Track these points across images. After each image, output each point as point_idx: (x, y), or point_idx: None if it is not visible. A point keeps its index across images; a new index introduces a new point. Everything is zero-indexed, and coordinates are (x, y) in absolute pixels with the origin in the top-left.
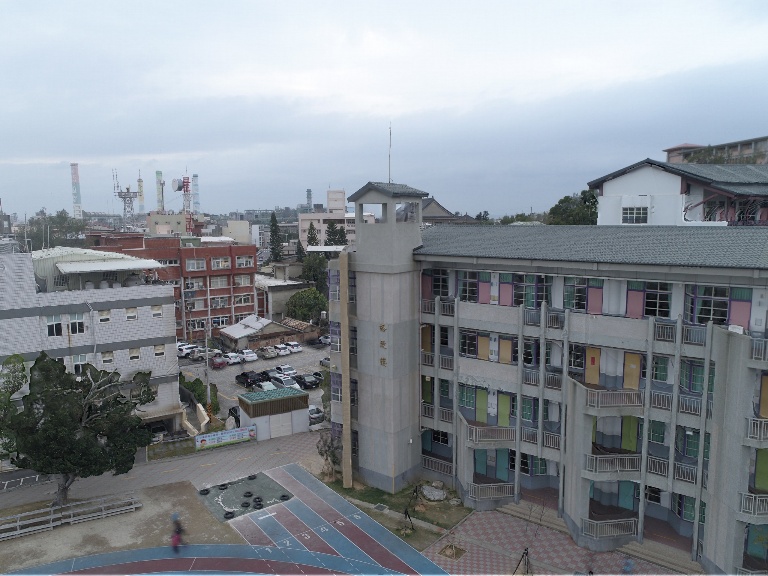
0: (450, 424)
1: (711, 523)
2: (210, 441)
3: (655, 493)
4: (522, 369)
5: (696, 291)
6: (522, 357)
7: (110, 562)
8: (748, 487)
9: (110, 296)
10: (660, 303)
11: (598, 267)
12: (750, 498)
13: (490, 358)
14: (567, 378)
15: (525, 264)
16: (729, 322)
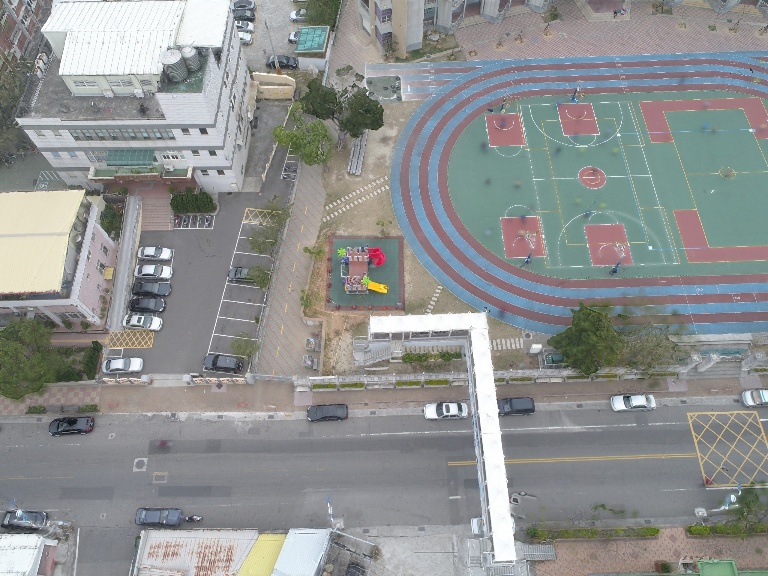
0: (433, 3)
1: None
2: (324, 83)
3: None
4: None
5: None
6: None
7: (407, 138)
8: None
9: (227, 42)
10: None
11: None
12: None
13: None
14: None
15: None
16: None
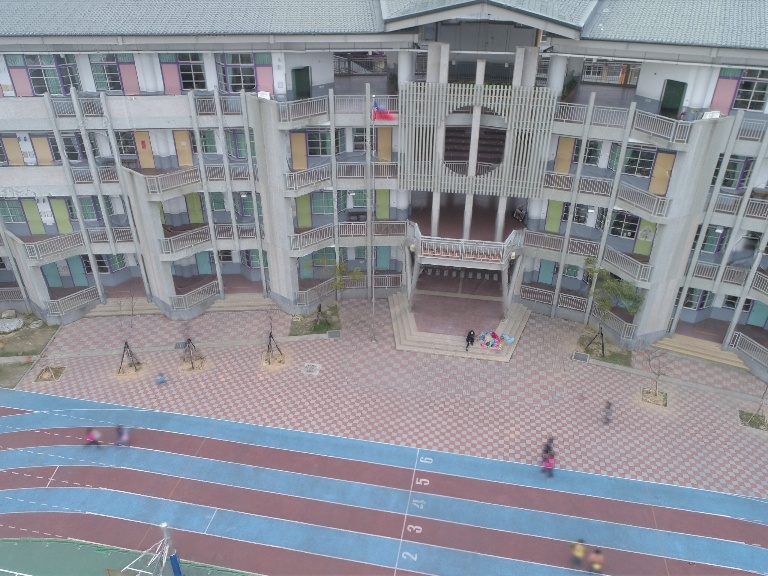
0: (1, 247)
1: (273, 265)
2: None
3: (227, 254)
4: (69, 168)
5: (225, 59)
6: (65, 154)
7: None
8: (294, 230)
9: None
10: (195, 75)
11: (123, 41)
12: (296, 238)
13: (26, 162)
14: (122, 169)
15: (35, 42)
16: (258, 88)
